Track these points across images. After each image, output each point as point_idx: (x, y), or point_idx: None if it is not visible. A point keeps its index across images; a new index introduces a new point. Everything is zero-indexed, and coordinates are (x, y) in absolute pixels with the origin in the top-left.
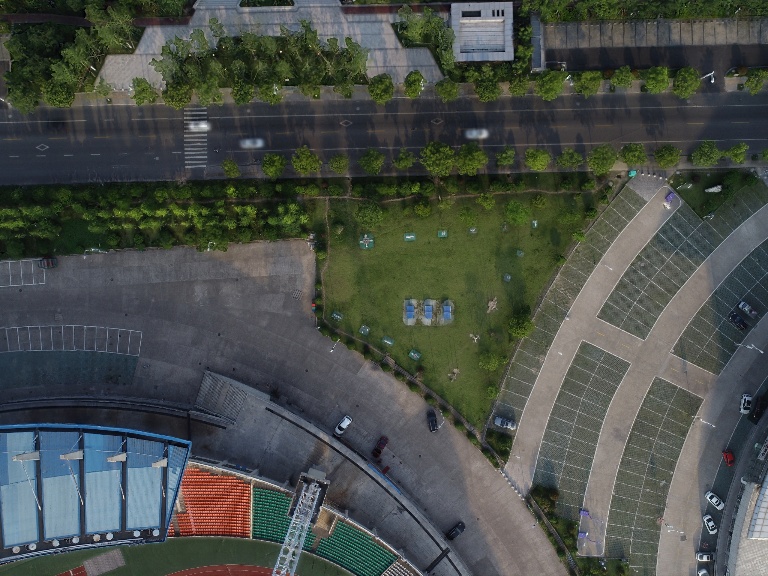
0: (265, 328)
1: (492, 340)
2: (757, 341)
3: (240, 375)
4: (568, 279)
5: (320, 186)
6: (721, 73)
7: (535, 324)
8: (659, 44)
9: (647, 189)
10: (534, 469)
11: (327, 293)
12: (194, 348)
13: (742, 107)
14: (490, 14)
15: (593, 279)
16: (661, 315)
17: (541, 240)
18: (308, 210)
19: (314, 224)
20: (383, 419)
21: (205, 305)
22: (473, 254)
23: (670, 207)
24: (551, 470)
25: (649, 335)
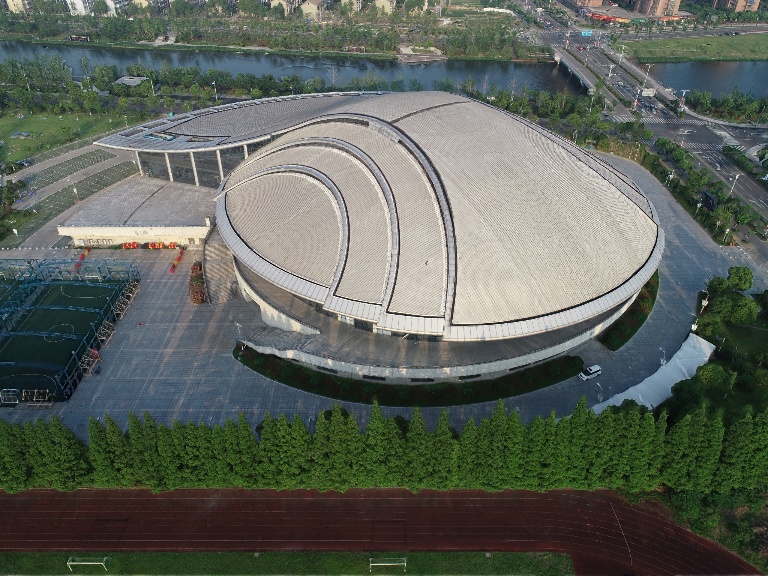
0: None
1: None
2: None
3: None
4: None
5: None
6: None
7: None
8: None
9: None
10: (21, 179)
11: None
12: None
13: None
14: None
15: None
16: None
17: None
18: None
19: None
20: None
21: None
22: None
23: None
24: (31, 180)
25: None
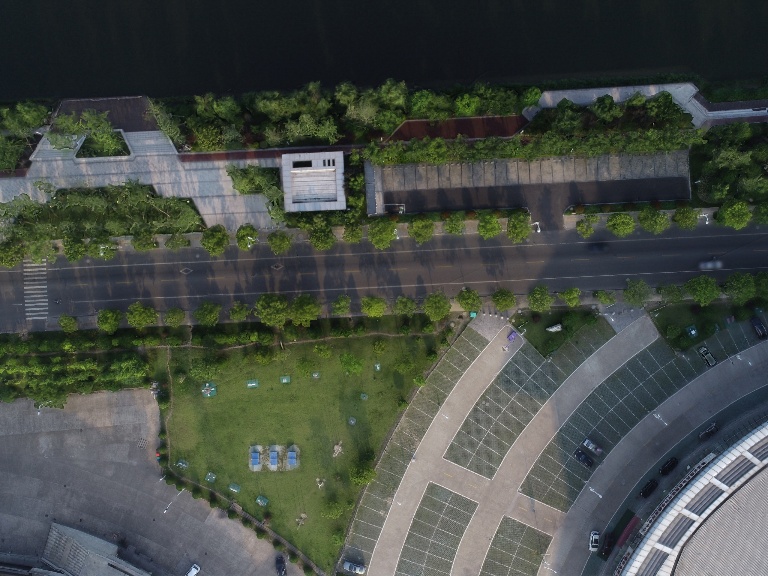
0: (111, 478)
1: (339, 484)
2: (604, 477)
3: (87, 526)
4: (413, 421)
5: (161, 335)
6: (559, 211)
7: (381, 467)
8: (497, 184)
9: (489, 329)
10: None
11: (172, 442)
12: (40, 500)
13: (581, 244)
14: (321, 164)
15: (438, 420)
16: (507, 454)
17: (384, 383)
18: (149, 360)
19: (156, 373)
20: (232, 566)
21: (50, 457)
22: (317, 399)
23: (508, 351)
24: None
25: (496, 474)
